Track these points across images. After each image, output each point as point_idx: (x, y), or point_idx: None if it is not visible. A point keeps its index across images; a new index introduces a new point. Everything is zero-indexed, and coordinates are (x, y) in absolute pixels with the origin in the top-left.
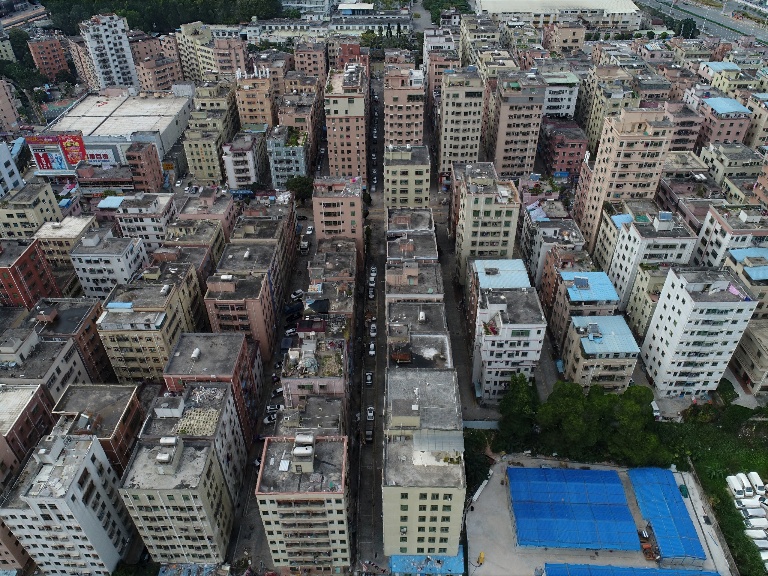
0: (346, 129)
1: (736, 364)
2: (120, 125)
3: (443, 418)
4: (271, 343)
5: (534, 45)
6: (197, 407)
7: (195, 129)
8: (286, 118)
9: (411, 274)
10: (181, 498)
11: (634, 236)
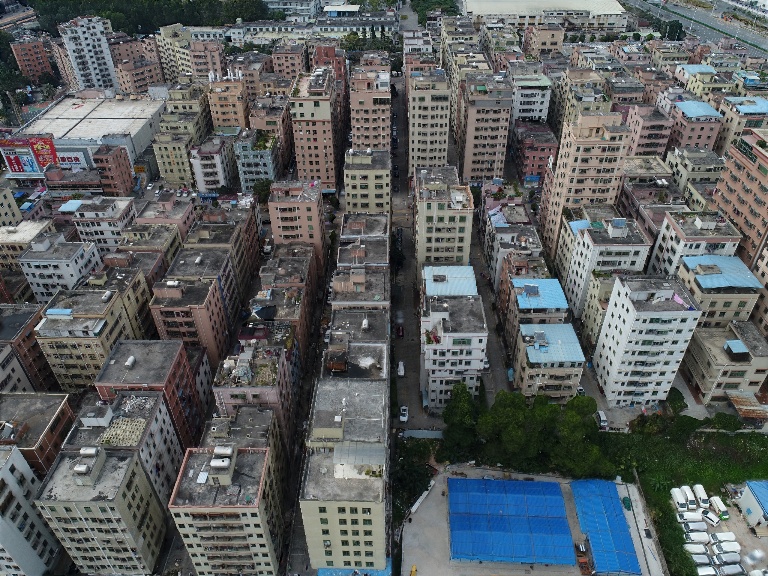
0: (313, 132)
1: (689, 373)
2: (93, 128)
3: (367, 430)
4: (222, 349)
5: (512, 47)
6: (126, 416)
7: (165, 132)
8: (257, 121)
9: (357, 281)
10: (98, 510)
11: (587, 243)
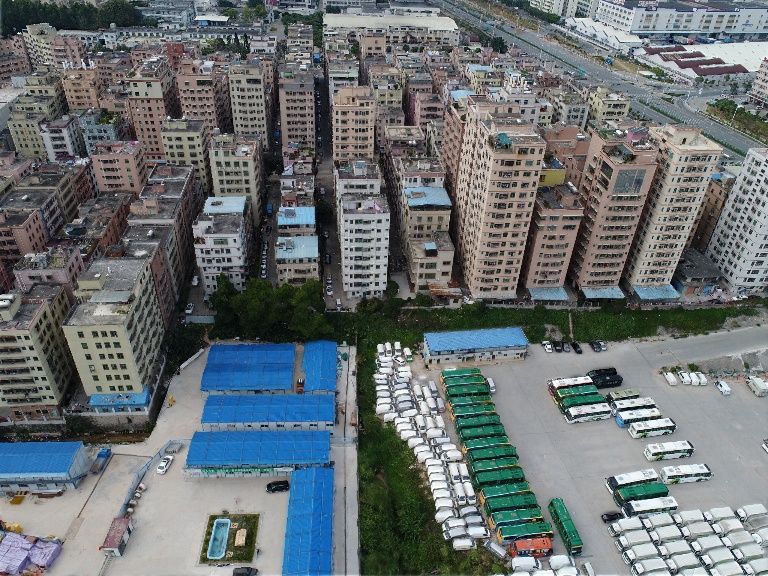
0: (148, 109)
1: None
2: None
3: (122, 285)
4: None
5: (342, 51)
6: None
7: (20, 111)
8: (106, 103)
9: (150, 205)
10: None
11: (337, 179)
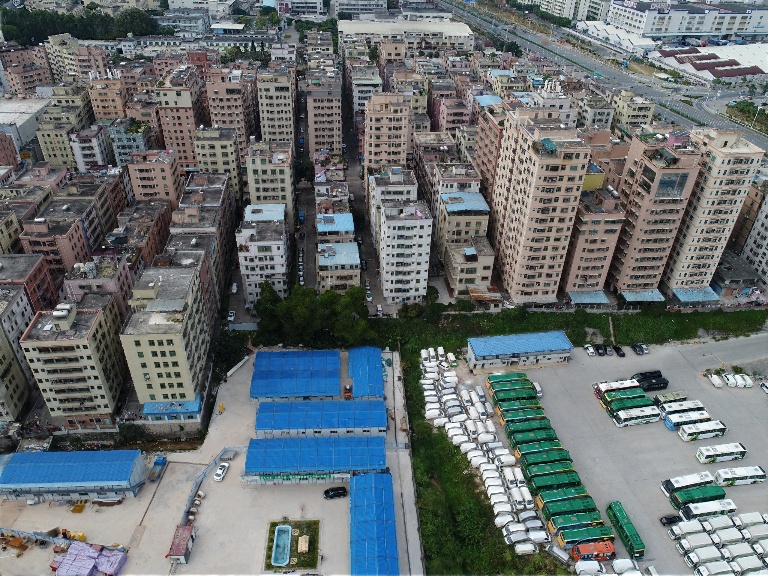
0: (177, 118)
1: None
2: None
3: (175, 293)
4: None
5: (363, 57)
6: None
7: (48, 121)
8: (133, 113)
9: (191, 214)
10: None
11: (374, 186)
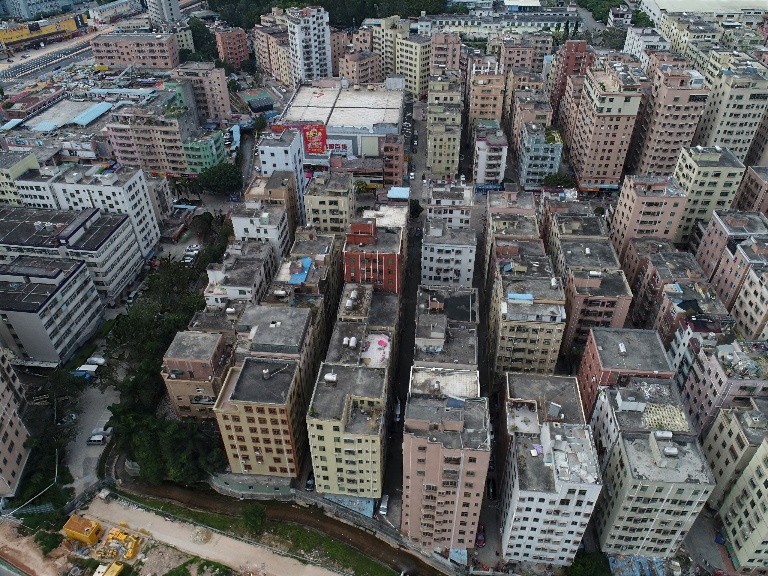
0: (614, 128)
1: None
2: (350, 116)
3: None
4: None
5: (757, 46)
6: (652, 402)
7: (438, 123)
8: (527, 114)
9: None
10: (690, 492)
11: None
